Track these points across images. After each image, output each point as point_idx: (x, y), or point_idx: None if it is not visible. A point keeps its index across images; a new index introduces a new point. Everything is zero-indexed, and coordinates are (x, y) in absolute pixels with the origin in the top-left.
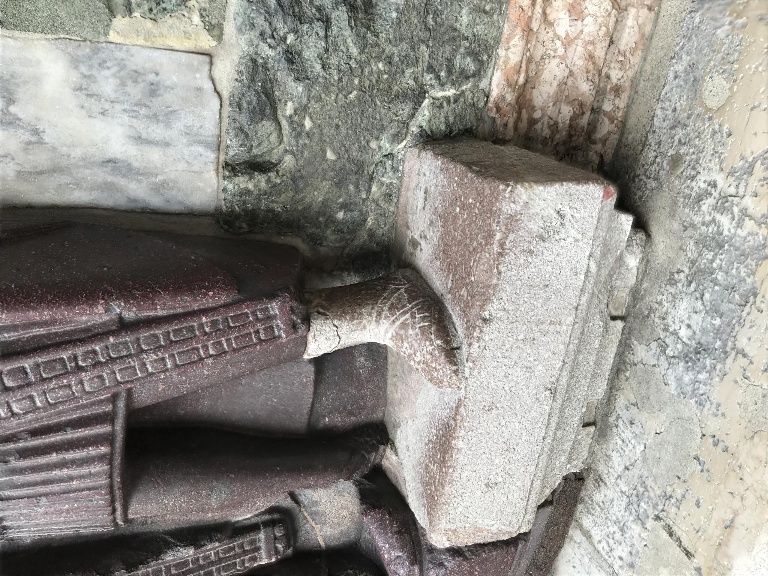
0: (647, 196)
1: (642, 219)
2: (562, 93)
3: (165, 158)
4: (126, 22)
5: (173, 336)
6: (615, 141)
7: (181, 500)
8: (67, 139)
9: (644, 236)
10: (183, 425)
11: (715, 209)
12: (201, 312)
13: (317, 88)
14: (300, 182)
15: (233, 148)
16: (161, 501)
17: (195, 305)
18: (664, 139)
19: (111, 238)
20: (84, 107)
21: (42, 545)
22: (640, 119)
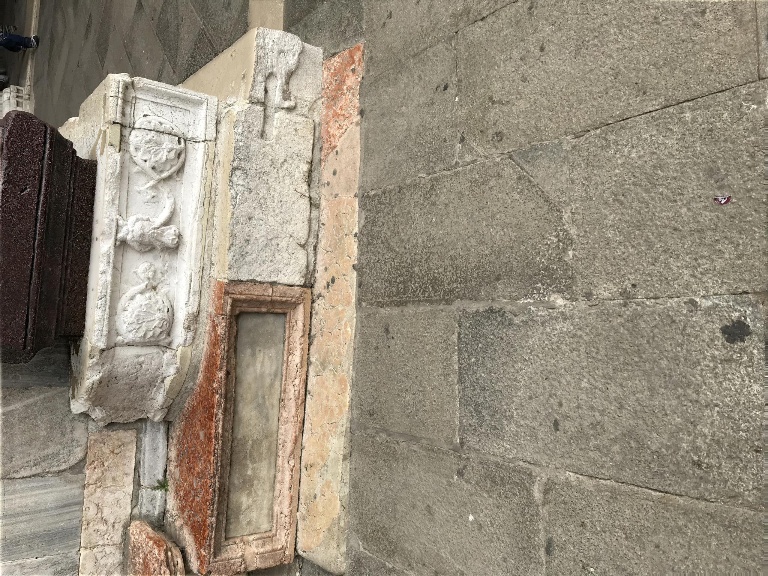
0: None
1: None
2: None
3: None
4: None
5: None
6: None
7: None
8: None
9: None
10: None
11: None
12: None
13: None
14: None
15: None
16: None
17: None
18: None
19: None
20: None
21: None
22: None
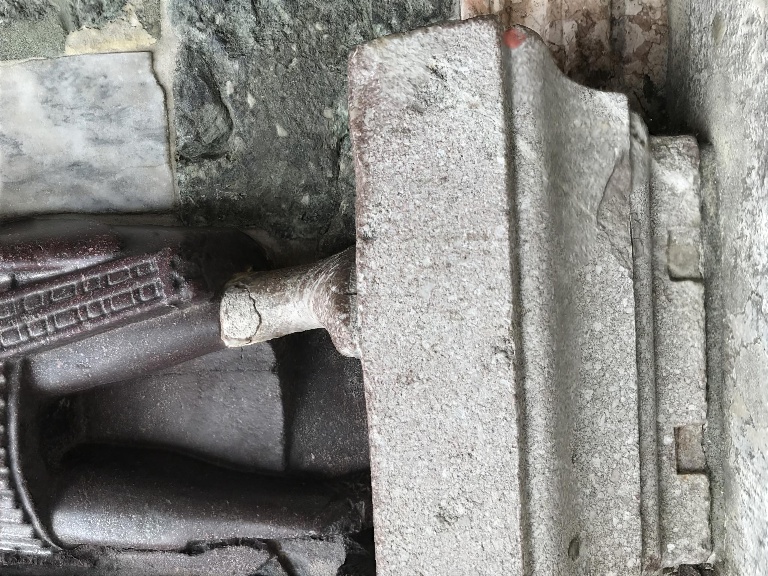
0: (703, 96)
1: (704, 130)
2: (559, 9)
3: (121, 156)
4: (75, 35)
5: (54, 296)
6: (664, 54)
7: (108, 522)
8: (40, 148)
9: (692, 142)
10: (146, 446)
11: (765, 48)
12: (81, 270)
13: (254, 62)
14: (253, 166)
15: (182, 138)
16: (86, 519)
17: (77, 263)
18: (703, 8)
19: (49, 223)
20: (51, 117)
21: (13, 575)
22: (681, 7)
